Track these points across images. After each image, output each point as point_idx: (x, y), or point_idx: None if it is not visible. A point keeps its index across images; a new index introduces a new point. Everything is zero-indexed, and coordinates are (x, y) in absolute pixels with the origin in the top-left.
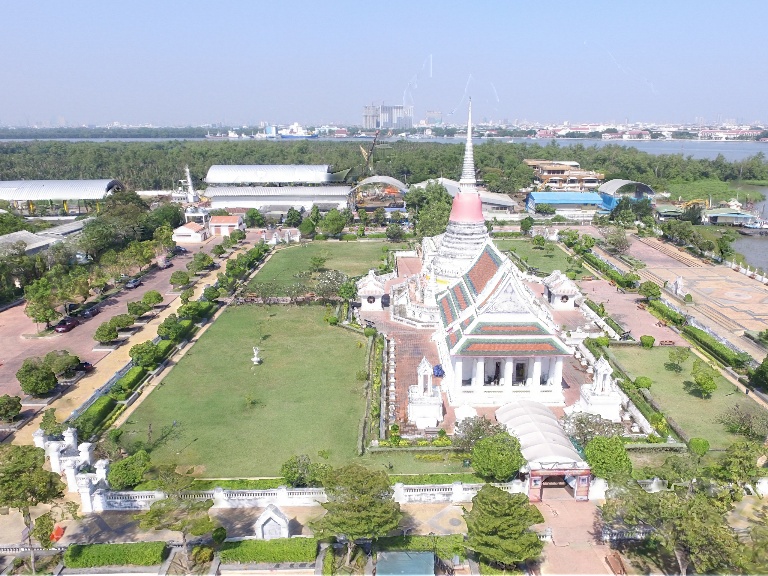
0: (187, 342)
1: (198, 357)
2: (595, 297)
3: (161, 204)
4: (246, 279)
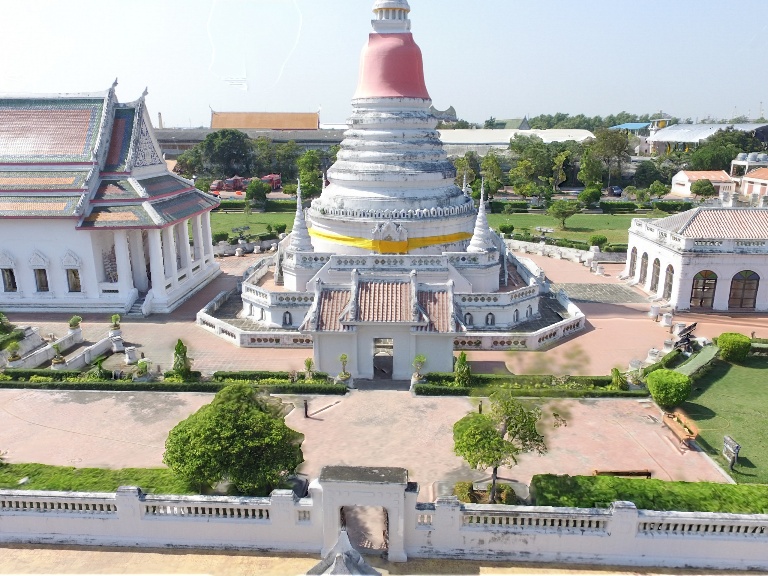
0: (261, 211)
1: (220, 215)
2: (391, 405)
3: (728, 146)
4: (499, 213)
